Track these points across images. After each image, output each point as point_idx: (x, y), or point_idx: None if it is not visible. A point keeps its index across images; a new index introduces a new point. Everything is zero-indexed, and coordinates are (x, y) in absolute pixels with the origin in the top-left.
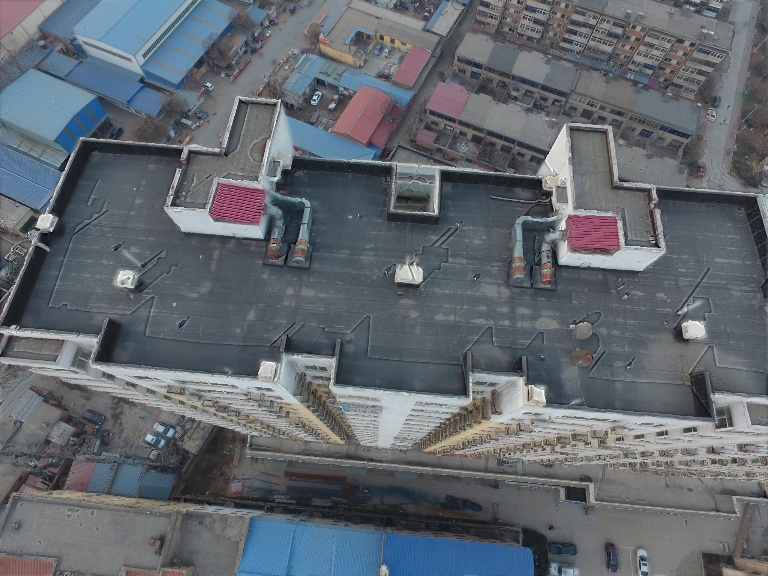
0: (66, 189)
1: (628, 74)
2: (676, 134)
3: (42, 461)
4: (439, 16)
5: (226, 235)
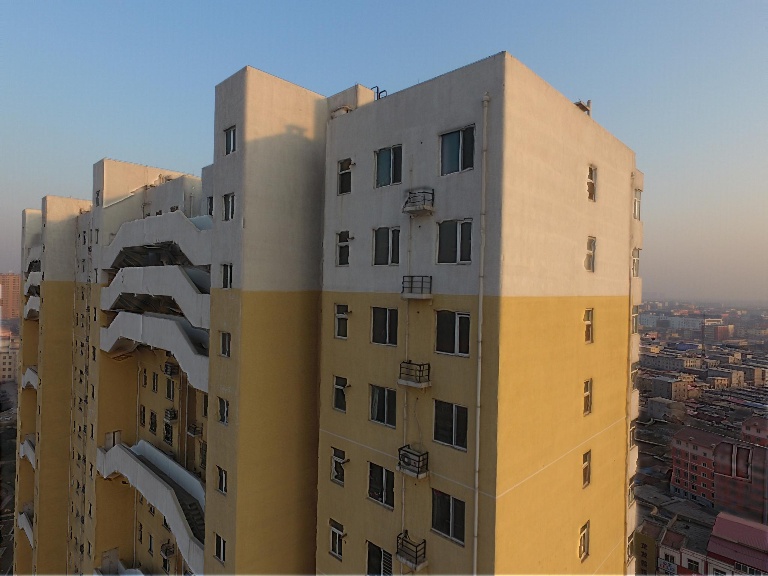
0: None
1: None
2: None
3: None
4: None
5: None
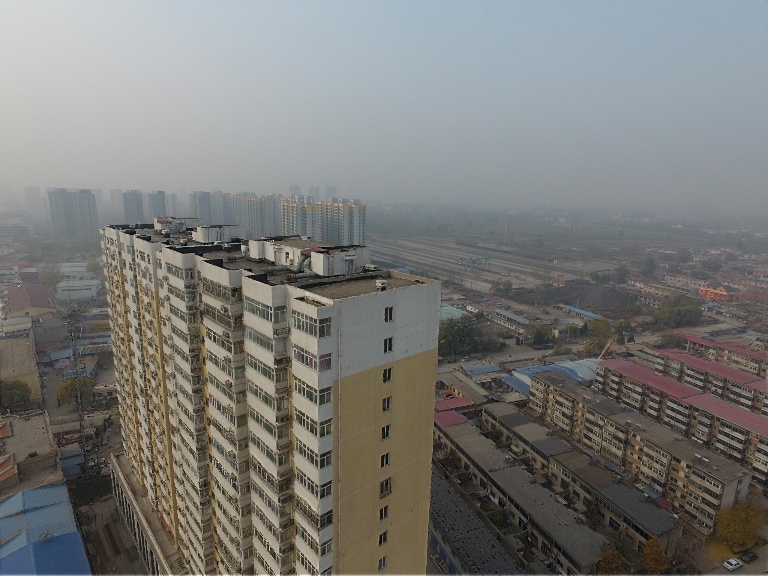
0: None
1: (638, 484)
2: (640, 533)
3: (68, 436)
4: (503, 395)
5: None
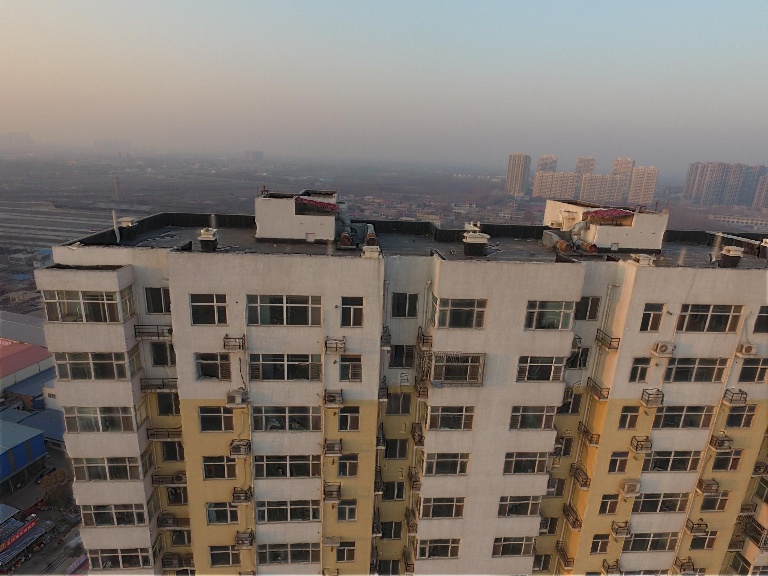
0: (145, 223)
1: None
2: None
3: None
4: None
5: (298, 238)
